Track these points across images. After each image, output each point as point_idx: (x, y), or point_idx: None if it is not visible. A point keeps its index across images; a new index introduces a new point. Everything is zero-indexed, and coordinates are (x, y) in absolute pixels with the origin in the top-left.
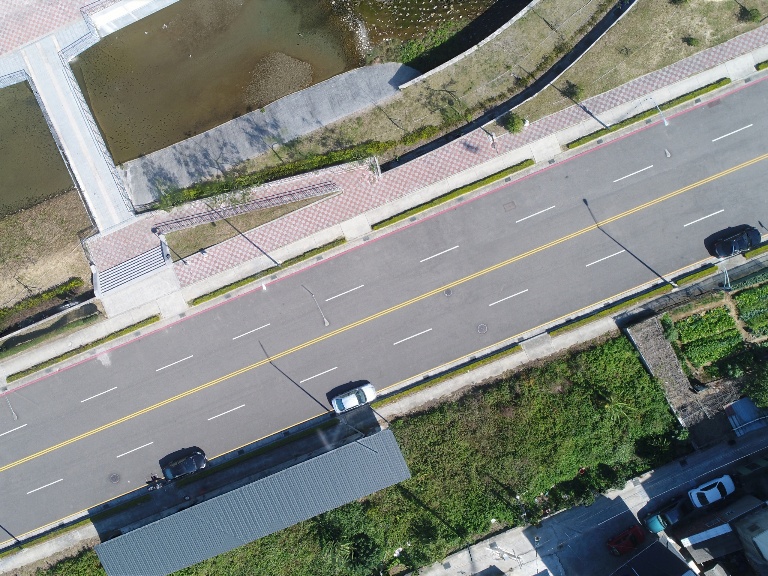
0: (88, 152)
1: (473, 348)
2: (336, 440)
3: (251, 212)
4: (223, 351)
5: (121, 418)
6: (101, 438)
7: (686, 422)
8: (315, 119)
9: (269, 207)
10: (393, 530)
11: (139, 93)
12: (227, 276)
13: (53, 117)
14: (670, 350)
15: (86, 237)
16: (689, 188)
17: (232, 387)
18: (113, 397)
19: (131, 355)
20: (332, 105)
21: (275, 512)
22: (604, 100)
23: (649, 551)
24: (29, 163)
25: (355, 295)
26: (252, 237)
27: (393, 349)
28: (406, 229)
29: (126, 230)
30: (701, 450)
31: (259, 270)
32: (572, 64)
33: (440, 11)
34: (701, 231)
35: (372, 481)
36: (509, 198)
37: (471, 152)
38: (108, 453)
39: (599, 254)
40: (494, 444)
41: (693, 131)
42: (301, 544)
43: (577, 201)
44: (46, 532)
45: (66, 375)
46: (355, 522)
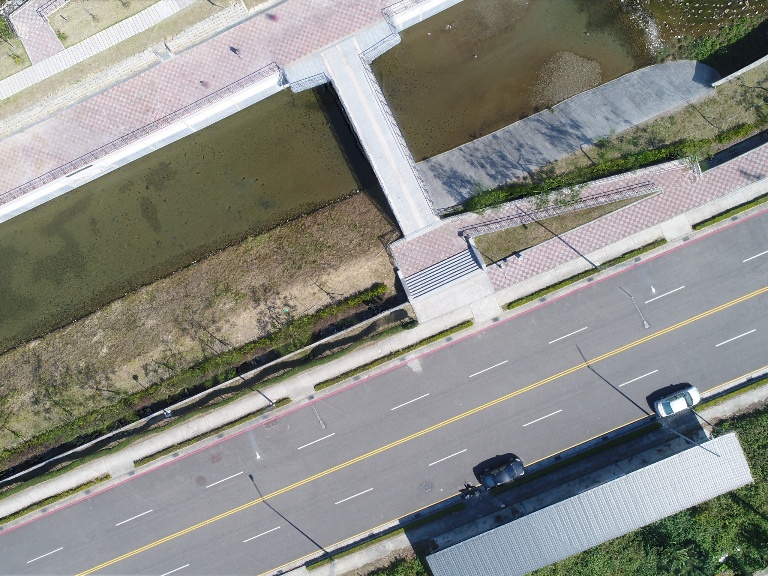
0: (391, 155)
1: None
2: (657, 444)
3: (565, 214)
4: (539, 356)
5: (433, 425)
6: (413, 446)
7: None
8: (621, 118)
9: (584, 208)
10: (722, 535)
11: (422, 95)
12: (543, 279)
13: (355, 120)
14: None
15: (389, 242)
16: None
17: (549, 392)
18: (425, 404)
19: (443, 361)
20: (636, 104)
21: (613, 519)
22: None
23: None
24: (309, 168)
25: (676, 296)
26: (569, 239)
27: (715, 351)
28: (728, 229)
29: (431, 234)
30: None
31: (576, 273)
32: None
33: (734, 7)
34: None
35: (713, 486)
36: None
37: None
38: (420, 461)
39: None
40: None
41: None
42: (627, 551)
43: None
44: (355, 543)
45: (375, 382)
46: (682, 528)
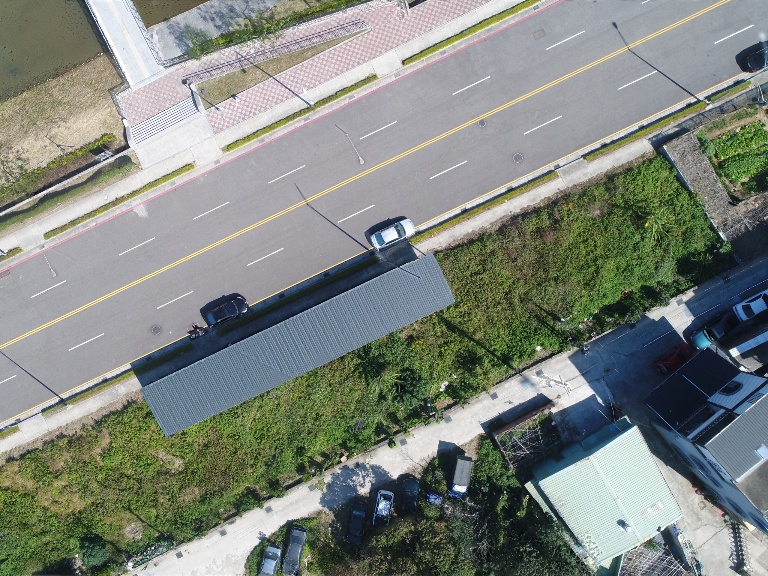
0: (115, 8)
1: (509, 178)
2: None
3: (281, 56)
4: (259, 195)
5: (160, 269)
6: (141, 290)
7: (727, 236)
8: None
9: (299, 50)
10: (438, 363)
11: None
12: (260, 120)
13: None
14: (708, 165)
15: (117, 93)
16: (718, 5)
17: (270, 231)
18: (151, 248)
19: (167, 205)
20: None
21: (320, 344)
22: None
23: (699, 358)
24: (54, 33)
25: (389, 132)
26: (283, 79)
27: (429, 183)
28: (437, 63)
29: (156, 83)
30: (744, 262)
31: (292, 112)
32: None
33: None
34: (732, 47)
35: (416, 308)
36: (538, 26)
37: None
38: (148, 305)
39: (631, 76)
40: (536, 271)
41: None
42: (347, 382)
43: (606, 25)
44: (89, 388)
45: (103, 229)
46: (400, 357)
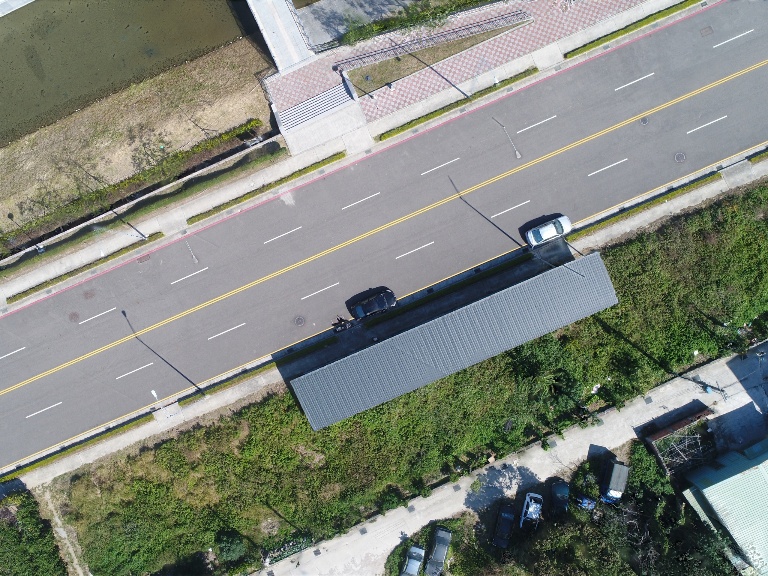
0: None
1: (670, 178)
2: (530, 275)
3: (438, 45)
4: (411, 187)
5: (306, 259)
6: (285, 280)
7: None
8: None
9: (456, 39)
10: (592, 365)
11: None
12: (415, 110)
13: None
14: None
15: (264, 77)
16: None
17: (421, 224)
18: (297, 237)
19: (315, 194)
20: None
21: (478, 342)
22: None
23: None
24: (193, 15)
25: (547, 126)
26: (440, 69)
27: (587, 181)
28: (599, 57)
29: (306, 69)
30: None
31: (448, 103)
32: None
33: None
34: None
35: (578, 307)
36: (706, 23)
37: None
38: (292, 295)
39: None
40: (696, 273)
41: None
42: (498, 381)
43: None
44: (228, 378)
45: (248, 216)
46: (553, 357)
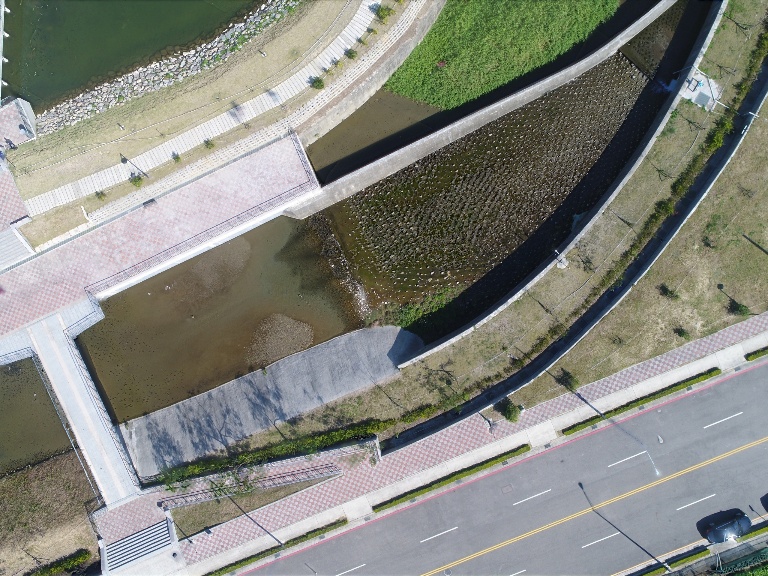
0: (94, 428)
1: None
2: None
3: (255, 491)
4: None
5: None
6: None
7: None
8: (316, 394)
9: (272, 486)
10: None
11: (143, 352)
12: (232, 555)
13: (59, 394)
14: None
15: (93, 510)
16: (681, 473)
17: None
18: None
19: None
20: (333, 377)
21: None
22: (598, 388)
23: None
24: (35, 419)
25: (357, 574)
26: (256, 517)
27: None
28: (406, 510)
29: (132, 504)
30: None
31: (263, 549)
32: (567, 351)
33: (437, 276)
34: (693, 515)
35: None
36: (506, 481)
37: (469, 437)
38: None
39: (594, 536)
40: None
41: (685, 418)
42: None
43: (573, 485)
44: None
45: None
46: None
